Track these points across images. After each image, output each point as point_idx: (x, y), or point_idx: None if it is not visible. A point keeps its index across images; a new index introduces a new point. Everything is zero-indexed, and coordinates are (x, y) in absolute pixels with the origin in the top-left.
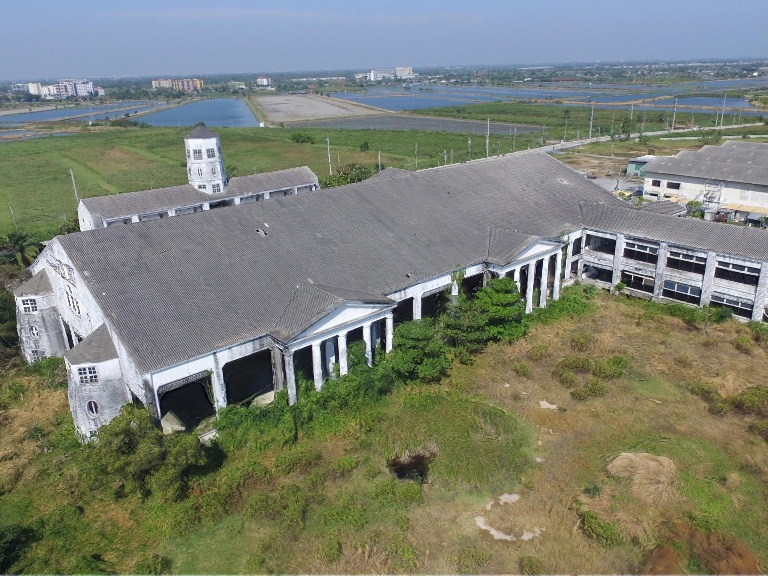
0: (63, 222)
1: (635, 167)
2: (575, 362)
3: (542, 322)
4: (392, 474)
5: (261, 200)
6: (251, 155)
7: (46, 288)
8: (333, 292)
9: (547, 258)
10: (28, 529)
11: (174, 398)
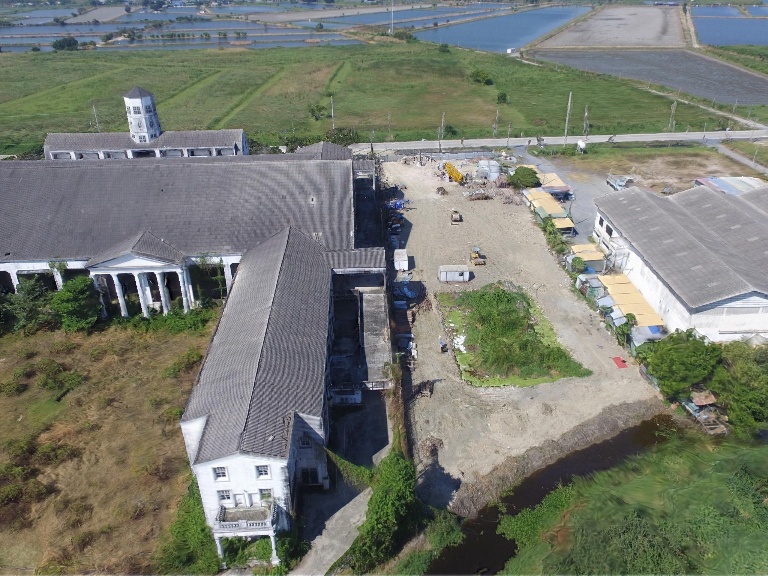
0: None
1: None
2: (44, 364)
3: (135, 326)
4: None
5: None
6: (398, 92)
7: None
8: None
9: (156, 273)
10: None
11: None
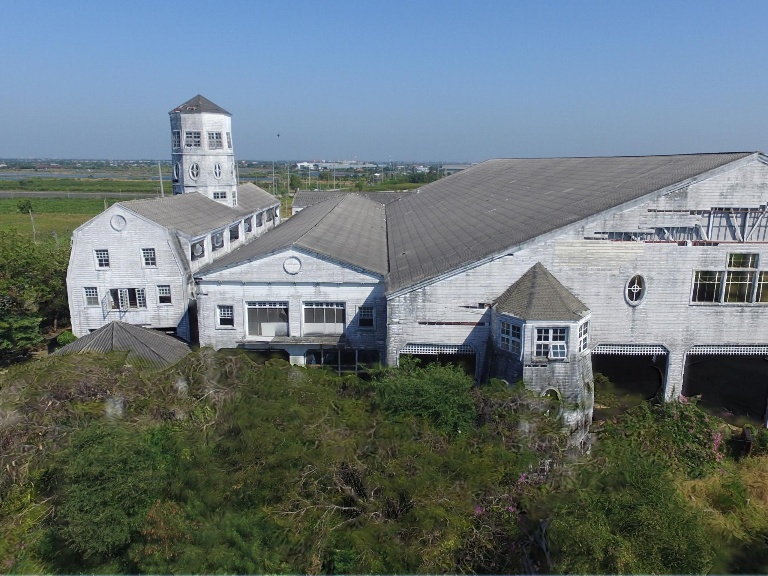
0: None
1: None
2: None
3: None
4: None
5: None
6: None
7: None
8: None
9: None
10: None
11: None
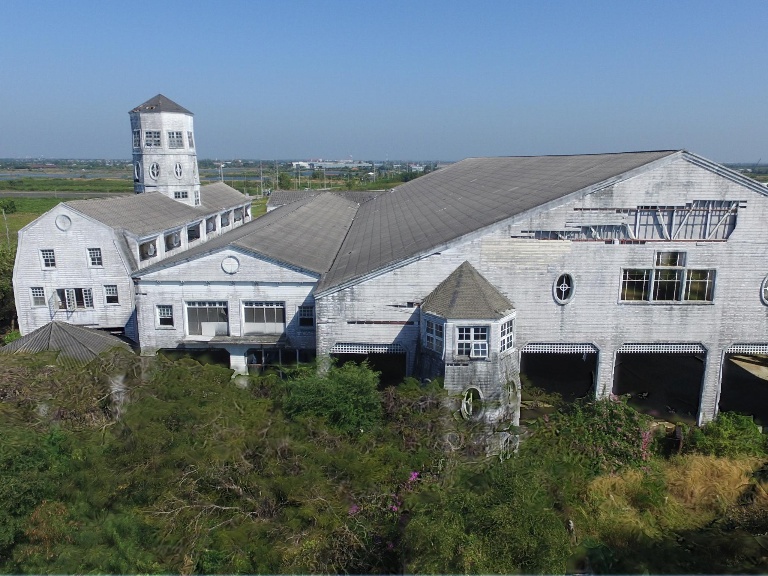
0: None
1: None
2: None
3: None
4: None
5: None
6: None
7: None
8: None
9: None
10: None
11: None
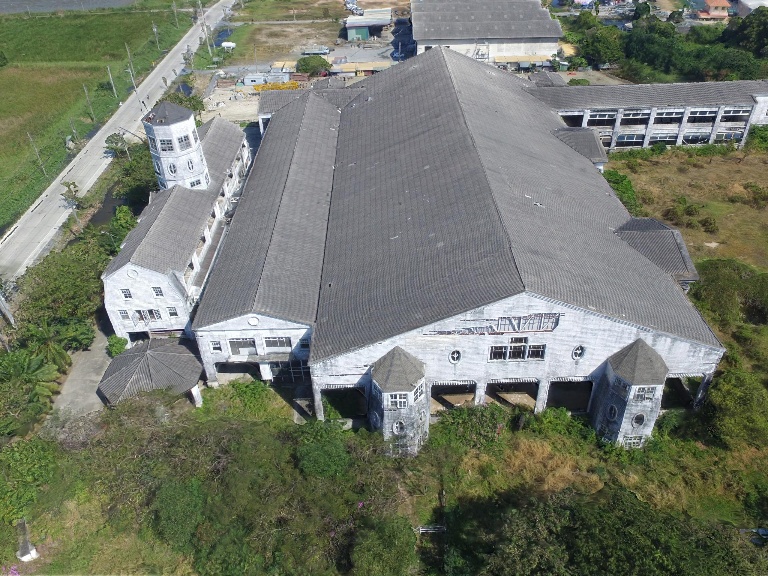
0: (25, 313)
1: (356, 32)
2: (680, 212)
3: None
4: (761, 325)
5: (486, 174)
6: None
7: (419, 365)
8: (649, 229)
9: None
10: (755, 503)
11: (573, 382)
